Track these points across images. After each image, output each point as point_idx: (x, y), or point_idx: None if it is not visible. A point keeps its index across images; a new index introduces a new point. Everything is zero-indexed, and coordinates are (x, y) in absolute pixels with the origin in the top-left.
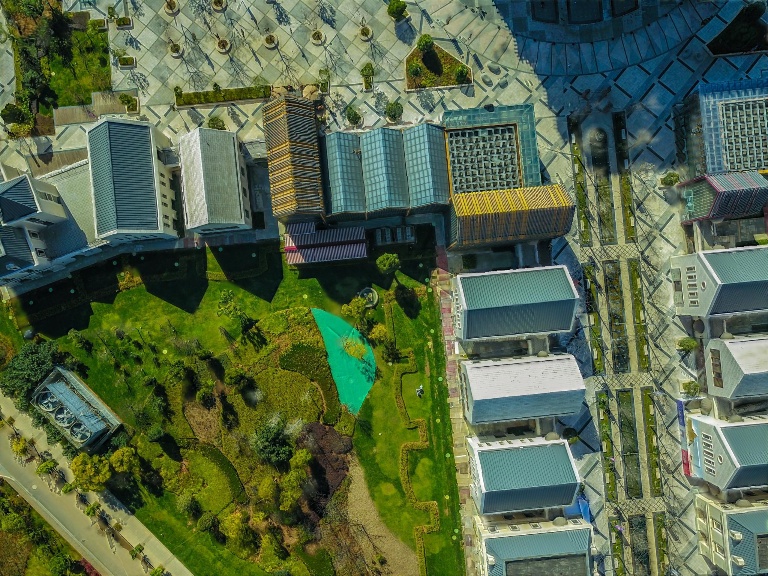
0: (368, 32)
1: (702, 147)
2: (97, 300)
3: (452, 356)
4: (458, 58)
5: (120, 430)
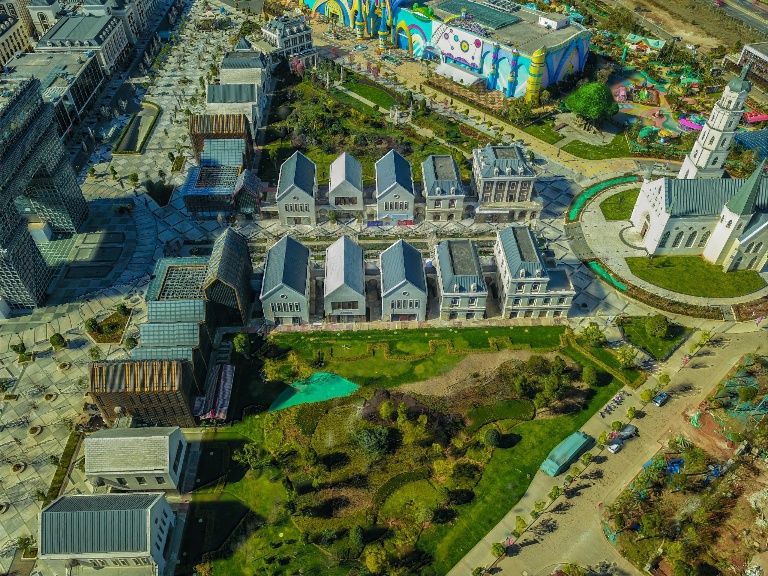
0: (64, 364)
1: (217, 198)
2: None
3: (323, 327)
4: (111, 315)
5: None
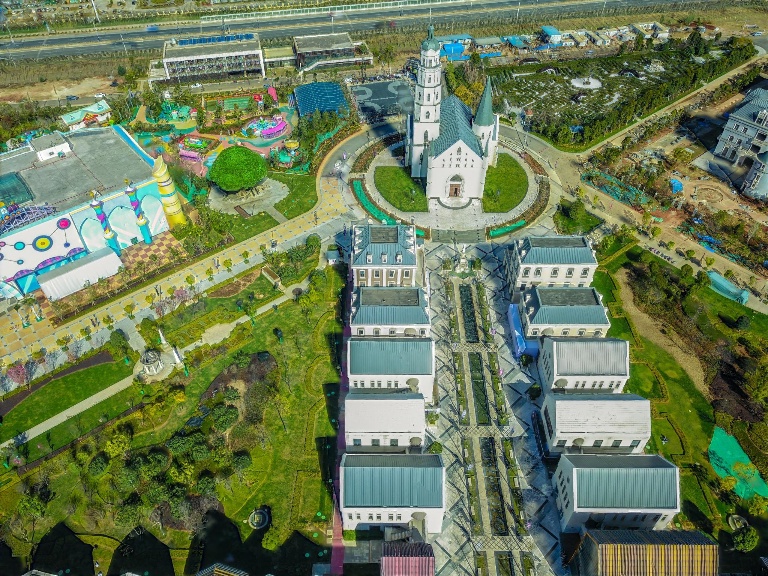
0: None
1: None
2: None
3: None
4: None
5: None
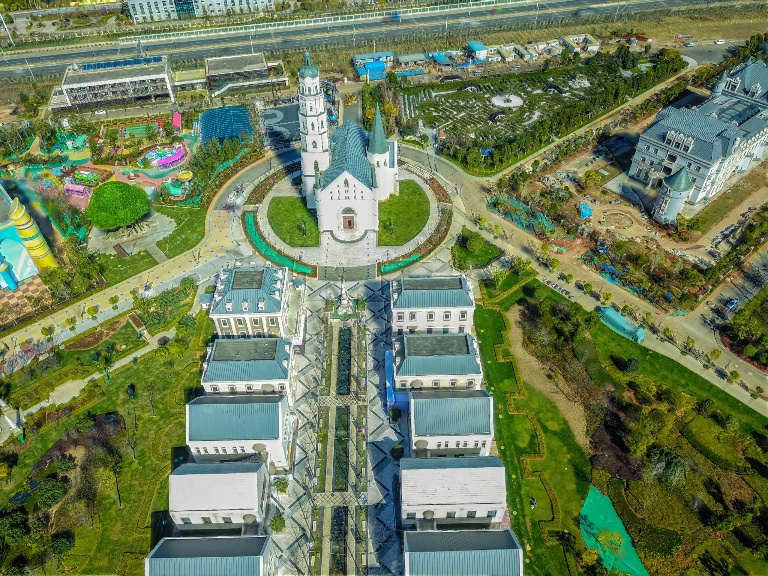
0: None
1: None
2: None
3: None
4: None
5: None
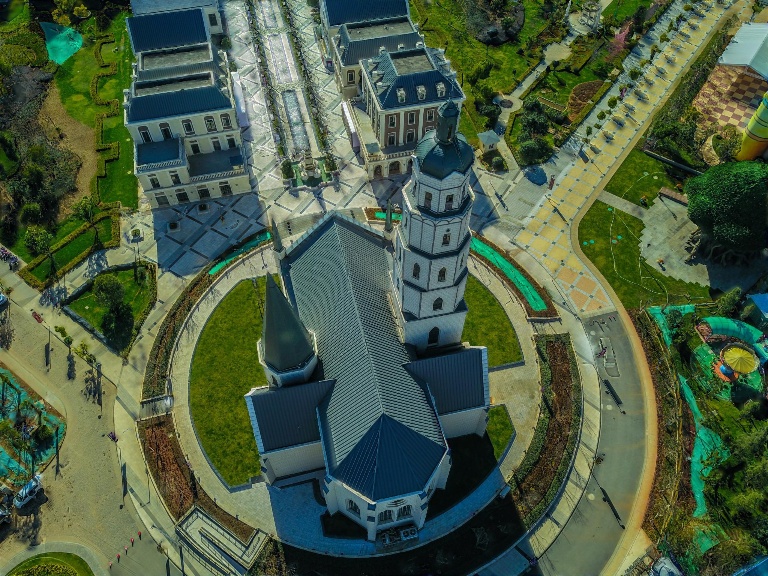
0: None
1: None
2: None
3: None
4: None
5: None
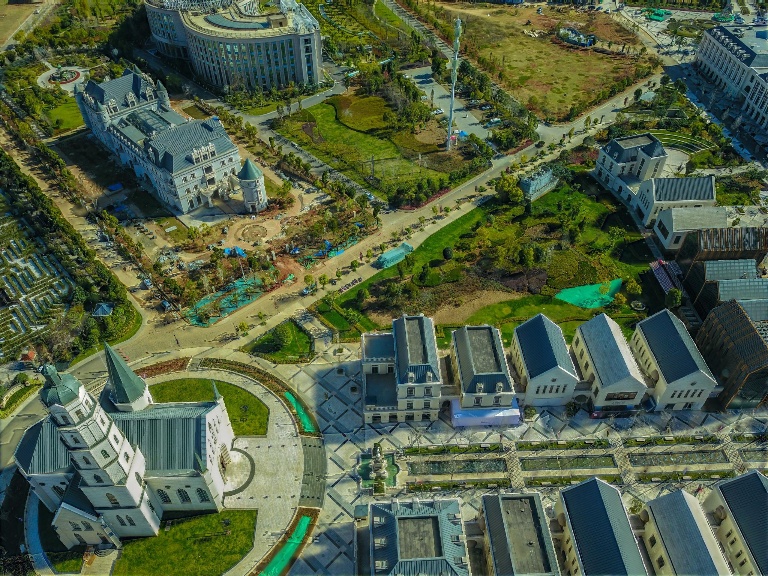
0: None
1: None
2: (597, 197)
3: None
4: None
5: (527, 201)
